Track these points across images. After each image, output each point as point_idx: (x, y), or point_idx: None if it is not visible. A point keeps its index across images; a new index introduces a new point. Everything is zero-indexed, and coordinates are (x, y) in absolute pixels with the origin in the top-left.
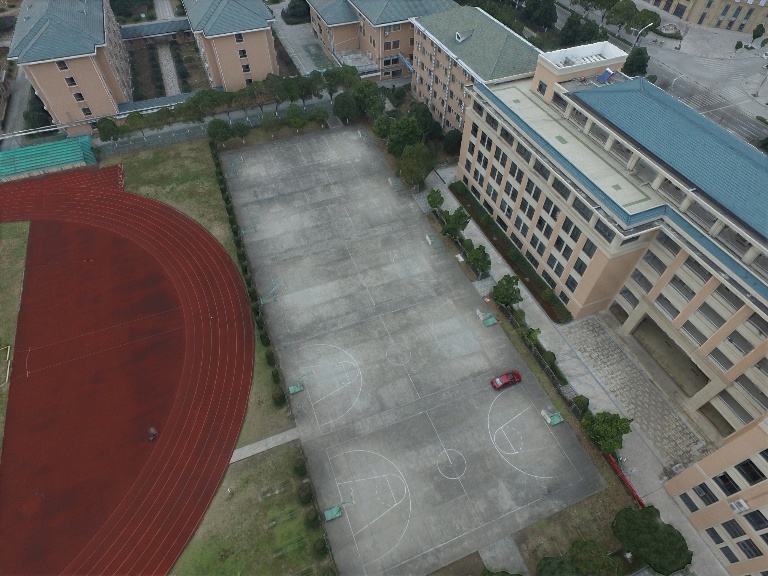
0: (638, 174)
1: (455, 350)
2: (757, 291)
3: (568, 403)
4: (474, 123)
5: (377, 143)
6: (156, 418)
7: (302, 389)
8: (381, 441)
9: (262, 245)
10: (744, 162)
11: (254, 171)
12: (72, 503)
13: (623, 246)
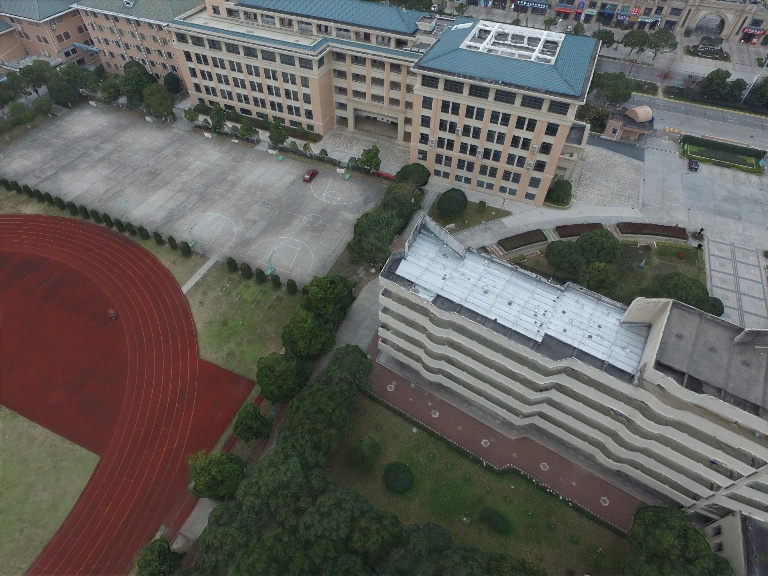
0: (303, 33)
1: (272, 179)
2: (384, 52)
3: (347, 167)
4: (185, 51)
5: (111, 109)
6: (105, 310)
7: (196, 242)
8: (267, 234)
9: (80, 199)
10: (345, 1)
11: (17, 165)
12: (90, 376)
13: (320, 69)
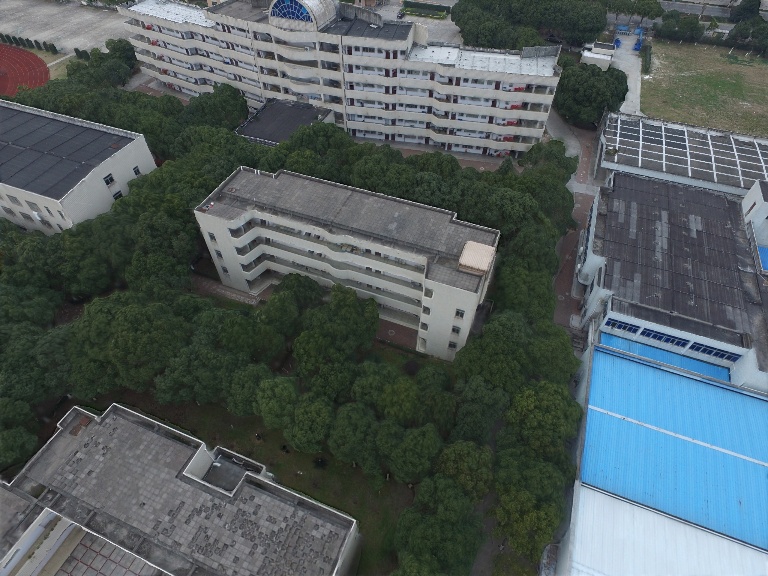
0: None
1: (121, 25)
2: None
3: None
4: None
5: None
6: None
7: (62, 49)
8: None
9: None
10: None
11: None
12: None
13: None
